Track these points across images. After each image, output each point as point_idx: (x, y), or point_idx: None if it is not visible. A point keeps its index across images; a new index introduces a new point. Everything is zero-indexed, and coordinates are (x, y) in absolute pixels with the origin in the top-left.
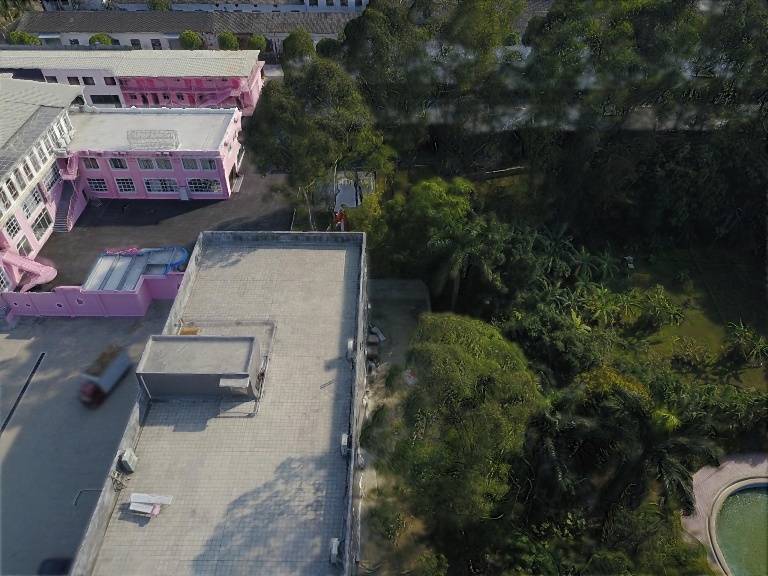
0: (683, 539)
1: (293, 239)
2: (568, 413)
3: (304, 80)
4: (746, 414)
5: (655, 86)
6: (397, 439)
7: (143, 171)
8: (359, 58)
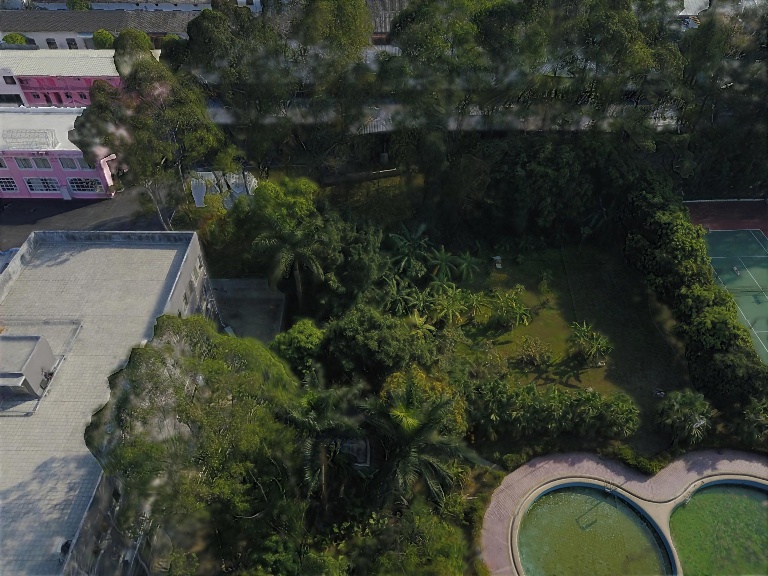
0: (441, 538)
1: (126, 238)
2: (326, 412)
3: None
4: (564, 414)
5: (505, 86)
6: (109, 438)
7: (22, 170)
8: (199, 58)
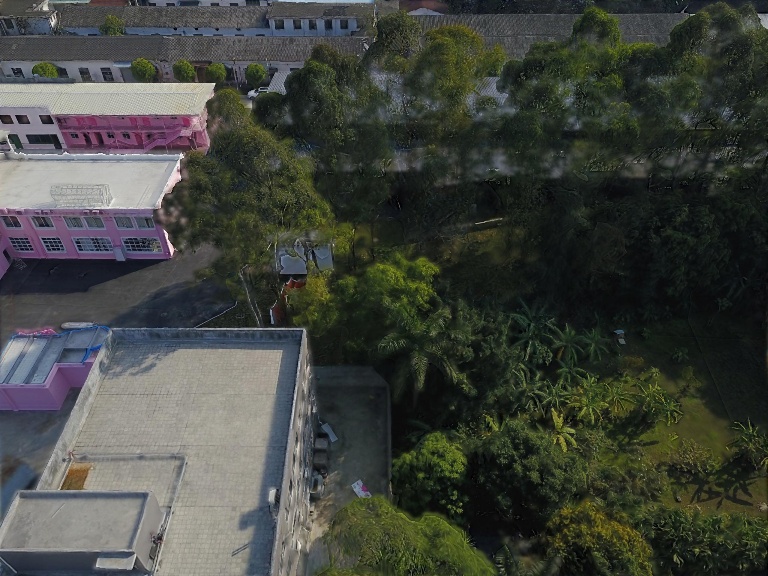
0: None
1: (220, 336)
2: None
3: (230, 150)
4: (758, 552)
5: (648, 145)
6: None
7: (71, 230)
8: (300, 118)
